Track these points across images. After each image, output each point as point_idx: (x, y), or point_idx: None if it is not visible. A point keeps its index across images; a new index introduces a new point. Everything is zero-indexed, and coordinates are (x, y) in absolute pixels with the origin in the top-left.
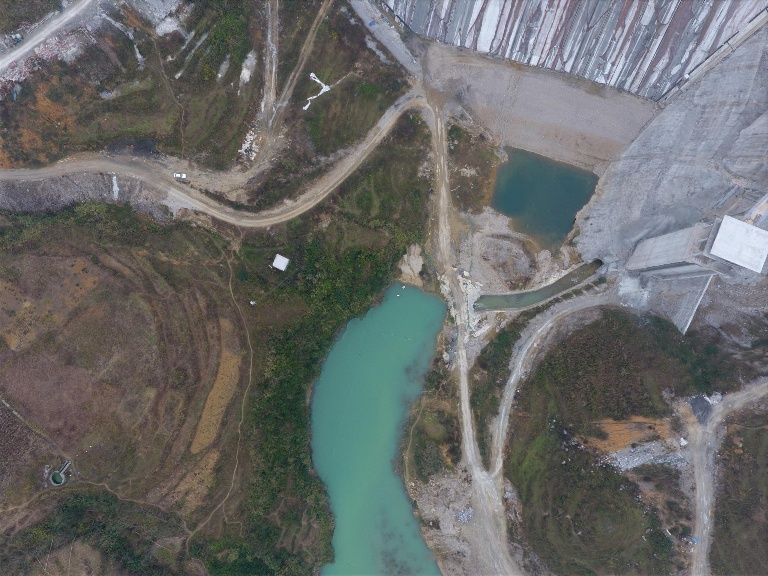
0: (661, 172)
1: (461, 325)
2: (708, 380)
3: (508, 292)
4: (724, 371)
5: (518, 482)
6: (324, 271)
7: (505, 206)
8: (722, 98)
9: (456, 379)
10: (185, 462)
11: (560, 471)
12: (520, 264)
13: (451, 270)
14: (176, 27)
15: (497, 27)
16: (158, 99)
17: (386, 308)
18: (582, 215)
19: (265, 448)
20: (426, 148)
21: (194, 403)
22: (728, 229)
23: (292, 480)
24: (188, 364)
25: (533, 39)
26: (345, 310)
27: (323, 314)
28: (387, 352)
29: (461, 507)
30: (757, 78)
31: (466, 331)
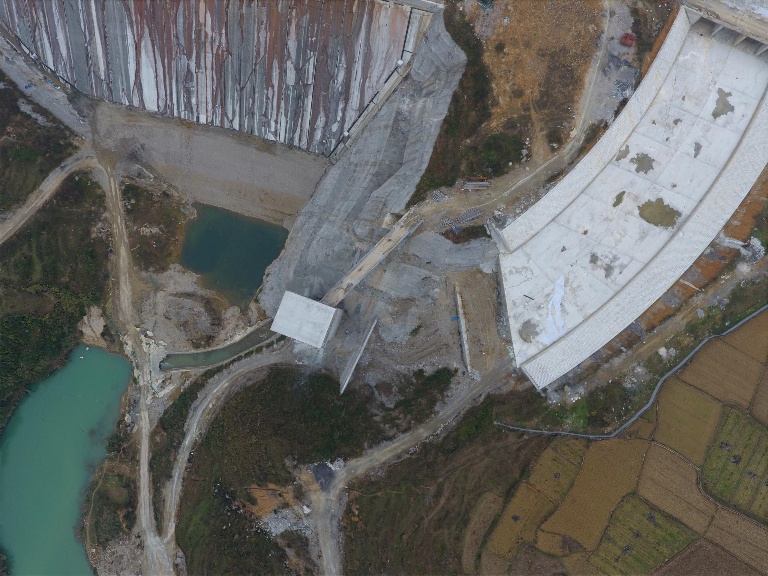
0: (313, 232)
1: (144, 386)
2: (336, 445)
3: (192, 351)
4: (356, 435)
5: (185, 548)
6: None
7: (196, 262)
8: (367, 157)
9: (137, 441)
10: None
11: (216, 537)
12: (201, 323)
13: (134, 330)
14: None
15: (157, 87)
16: None
17: (70, 370)
18: (267, 271)
19: None
20: (99, 209)
21: None
22: (288, 305)
23: None
24: None
25: (194, 99)
26: (9, 377)
27: None
28: (61, 417)
29: (131, 575)
30: (390, 139)
31: (149, 392)
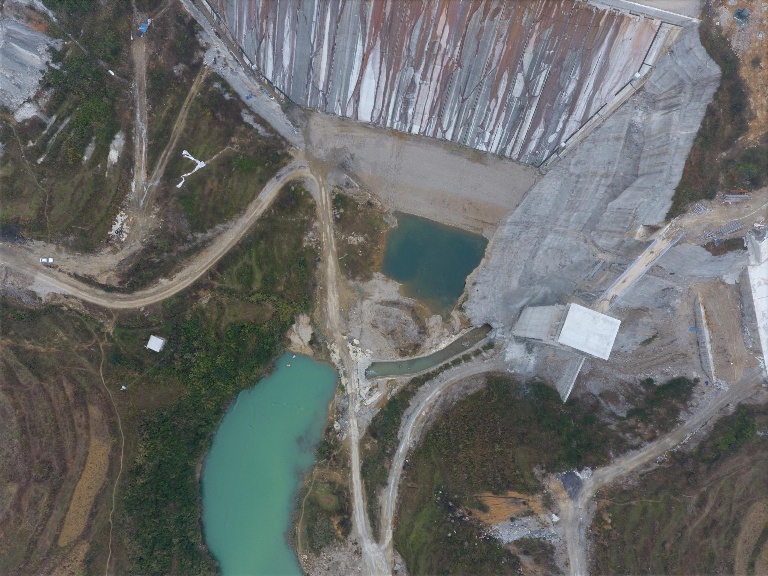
0: (537, 242)
1: (352, 394)
2: (580, 454)
3: (398, 359)
4: (597, 444)
5: (406, 555)
6: (203, 349)
7: (396, 271)
8: (593, 169)
9: (347, 449)
10: (52, 556)
11: (444, 544)
12: (409, 331)
13: (341, 338)
14: (35, 113)
15: (375, 98)
16: (20, 185)
17: (277, 378)
18: (471, 280)
19: (142, 533)
20: (310, 218)
21: (61, 495)
22: (575, 317)
23: (177, 561)
24: (53, 456)
25: (411, 109)
26: (229, 385)
27: (202, 393)
28: (275, 425)
29: None
30: (623, 151)
31: (357, 400)
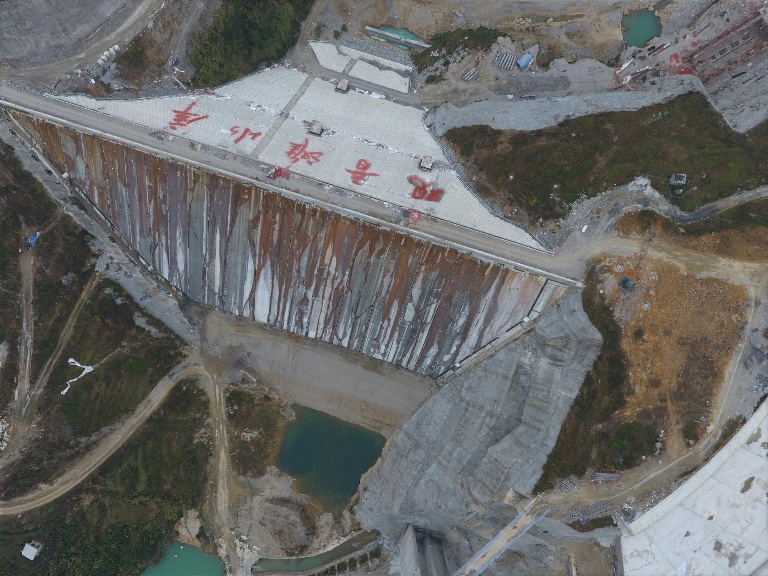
0: (421, 469)
1: None
2: None
3: (285, 558)
4: None
5: None
6: (79, 555)
7: (291, 464)
8: (481, 401)
9: None
10: None
11: None
12: (296, 533)
13: (229, 533)
14: None
15: (270, 305)
16: None
17: (164, 567)
18: (364, 481)
19: None
20: (203, 415)
21: None
22: None
23: None
24: None
25: (306, 318)
26: None
27: None
28: None
29: None
30: (509, 392)
31: None
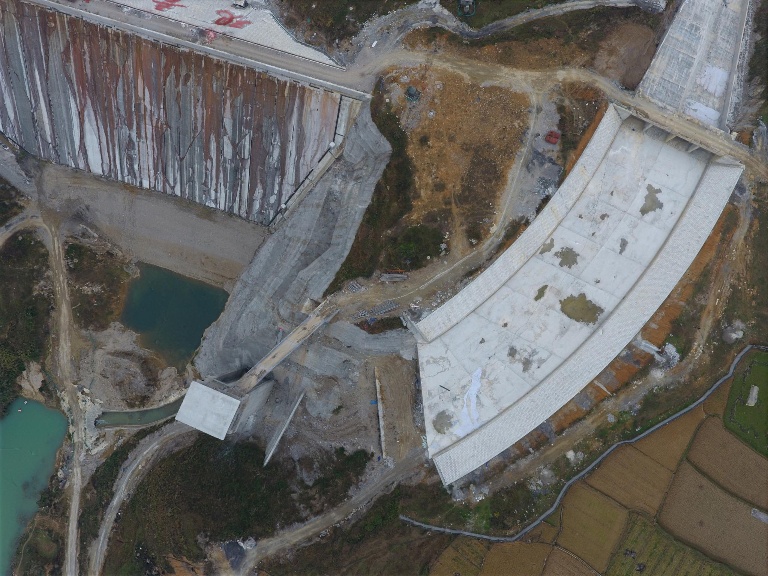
0: (244, 304)
1: (78, 442)
2: (250, 523)
3: (127, 410)
4: (271, 513)
5: None
6: None
7: (137, 321)
8: (299, 234)
9: (68, 497)
10: None
11: None
12: (136, 383)
13: (71, 387)
14: None
15: (101, 153)
16: None
17: (8, 423)
18: (205, 334)
19: None
20: (41, 267)
21: None
22: (194, 395)
23: None
24: None
25: (137, 165)
26: None
27: None
28: None
29: None
30: (320, 219)
31: (82, 449)
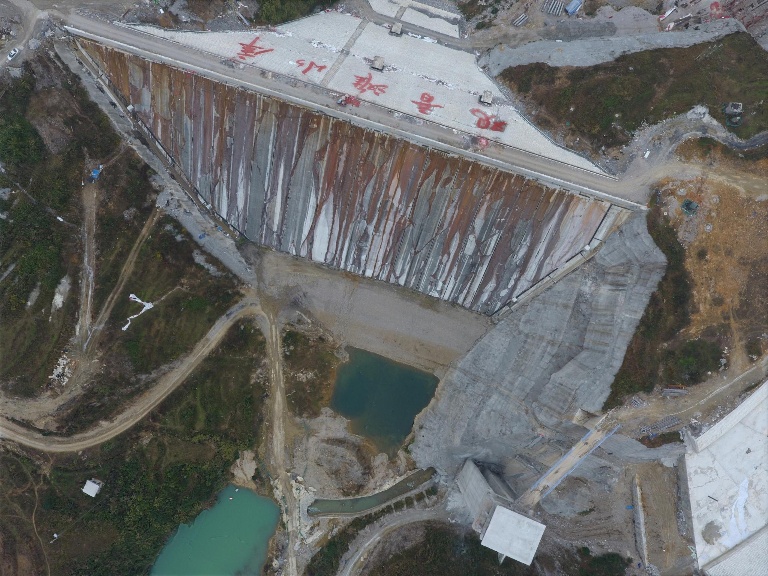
0: (482, 400)
1: (292, 531)
2: None
3: (341, 498)
4: None
5: None
6: (140, 492)
7: (345, 406)
8: (541, 332)
9: None
10: None
11: None
12: (353, 472)
13: (285, 475)
14: None
15: (329, 243)
16: None
17: (219, 511)
18: (419, 421)
19: None
20: (259, 355)
21: None
22: (500, 520)
23: None
24: None
25: (365, 256)
26: (167, 524)
27: (136, 538)
28: None
29: None
30: (570, 320)
31: (297, 538)
